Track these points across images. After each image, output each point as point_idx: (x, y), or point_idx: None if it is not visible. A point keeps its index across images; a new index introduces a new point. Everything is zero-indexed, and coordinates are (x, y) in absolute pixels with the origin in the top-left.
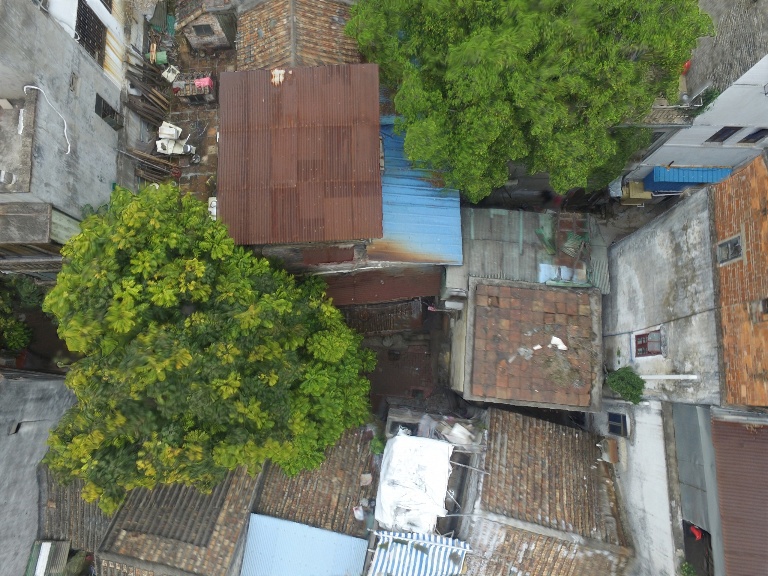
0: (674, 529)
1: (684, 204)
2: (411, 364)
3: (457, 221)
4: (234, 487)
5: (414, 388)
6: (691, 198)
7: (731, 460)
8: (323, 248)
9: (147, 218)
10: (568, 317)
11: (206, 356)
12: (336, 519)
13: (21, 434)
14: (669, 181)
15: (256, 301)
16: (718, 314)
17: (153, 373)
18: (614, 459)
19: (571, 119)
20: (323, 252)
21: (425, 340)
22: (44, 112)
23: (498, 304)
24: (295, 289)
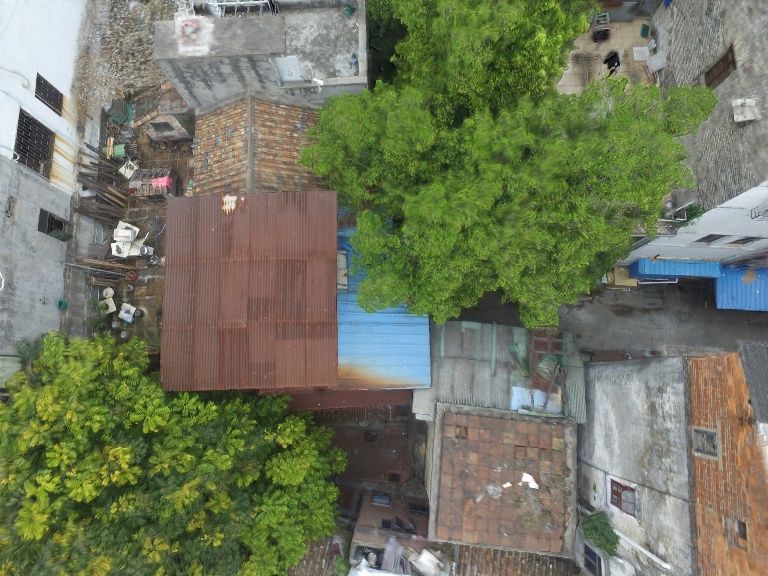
0: None
1: (660, 363)
2: (388, 446)
3: (425, 339)
4: None
5: (391, 472)
6: (667, 360)
7: None
8: None
9: (63, 410)
10: (541, 451)
11: (134, 543)
12: None
13: None
14: (655, 274)
15: (197, 464)
16: (692, 509)
17: None
18: None
19: (541, 257)
20: None
21: (403, 421)
22: None
23: (466, 435)
24: (250, 420)
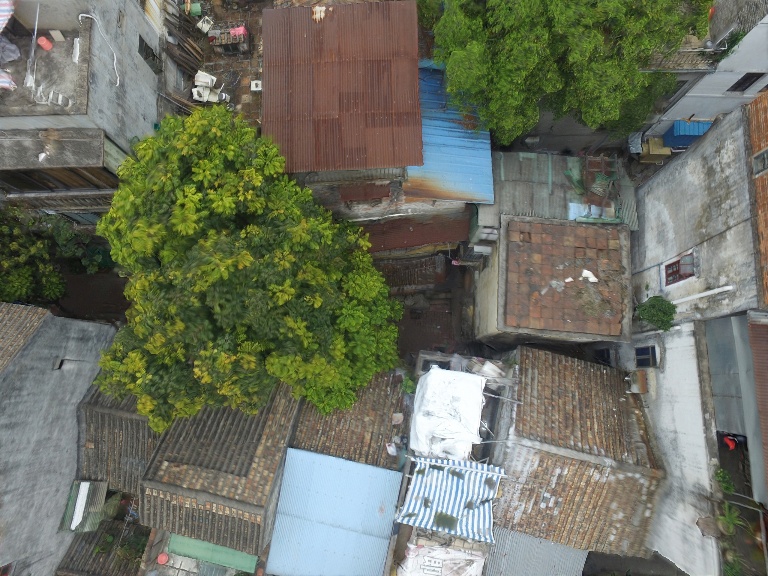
0: (708, 440)
1: (717, 127)
2: (433, 322)
3: (488, 162)
4: (270, 424)
5: (436, 345)
6: (724, 120)
7: None
8: (360, 185)
9: (209, 126)
10: (598, 251)
11: None
12: (370, 455)
13: (63, 371)
14: (689, 134)
15: None
16: (754, 222)
17: (217, 271)
18: (643, 389)
19: (605, 51)
20: (360, 189)
21: (446, 299)
22: (97, 42)
23: (530, 239)
24: (333, 224)
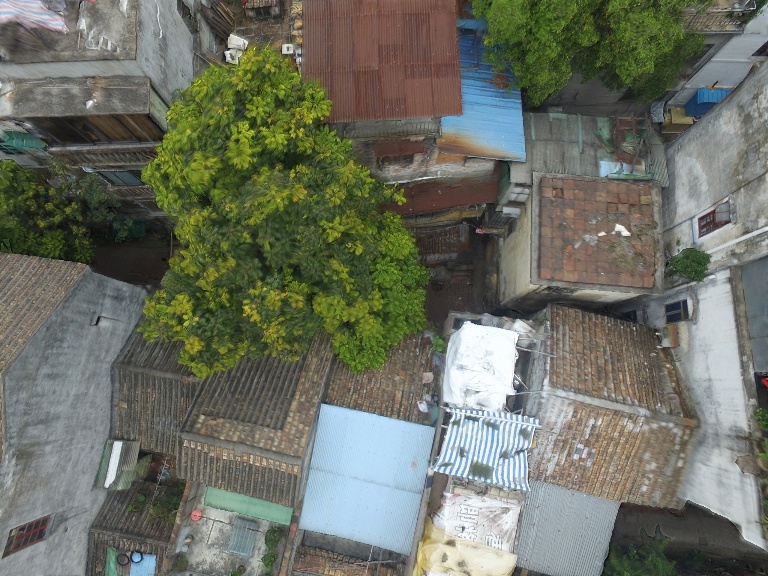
0: (746, 382)
1: (754, 75)
2: (454, 294)
3: (519, 121)
4: (303, 381)
5: None
6: (762, 66)
7: None
8: (395, 141)
9: (263, 63)
10: (630, 207)
11: None
12: (401, 412)
13: (100, 328)
14: (713, 102)
15: None
16: None
17: (273, 203)
18: (675, 342)
19: None
20: (395, 145)
21: (468, 270)
22: None
23: (562, 195)
24: None
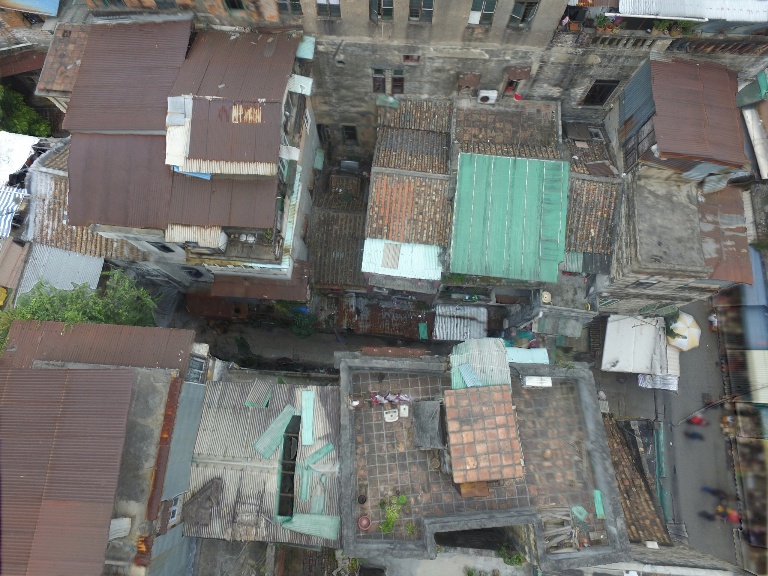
0: None
1: None
2: None
3: None
4: None
5: None
6: None
7: (93, 42)
8: None
9: None
10: None
11: None
12: None
13: None
14: None
15: None
16: None
17: None
18: None
19: None
20: None
21: None
22: None
23: (69, 35)
24: None
